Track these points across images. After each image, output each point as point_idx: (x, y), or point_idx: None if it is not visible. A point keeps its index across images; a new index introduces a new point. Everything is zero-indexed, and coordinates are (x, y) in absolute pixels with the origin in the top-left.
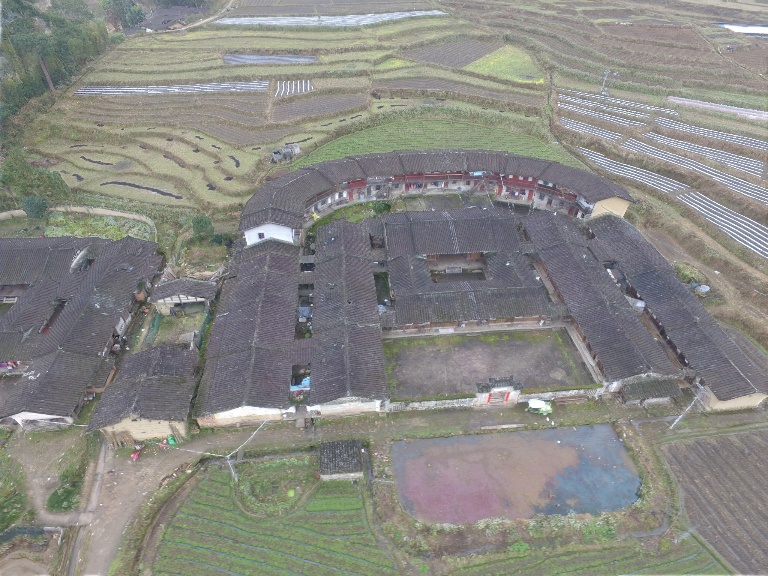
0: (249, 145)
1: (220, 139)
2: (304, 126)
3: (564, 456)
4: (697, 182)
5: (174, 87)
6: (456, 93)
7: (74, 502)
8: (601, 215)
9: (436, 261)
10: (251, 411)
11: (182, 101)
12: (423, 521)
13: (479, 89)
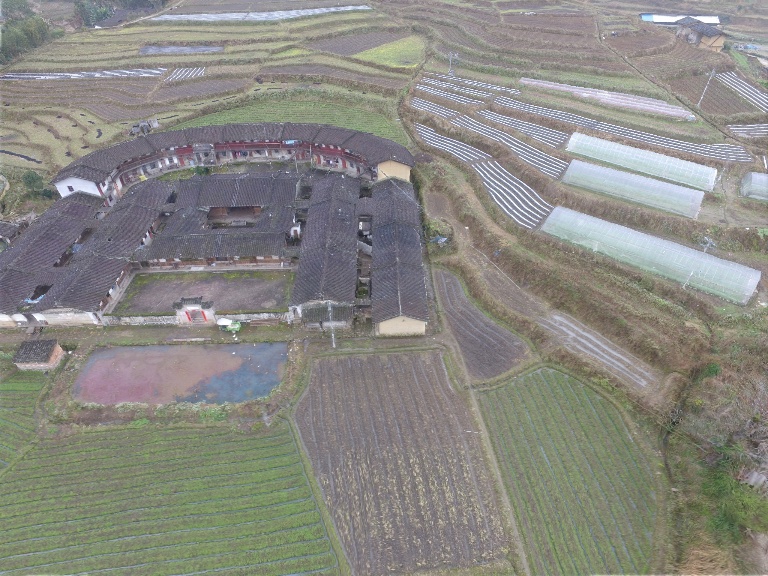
0: (119, 121)
1: (97, 116)
2: (177, 105)
3: (230, 363)
4: (497, 152)
5: (82, 73)
6: (330, 77)
7: None
8: (386, 178)
9: (227, 215)
10: None
11: (82, 85)
12: (80, 401)
13: (354, 74)
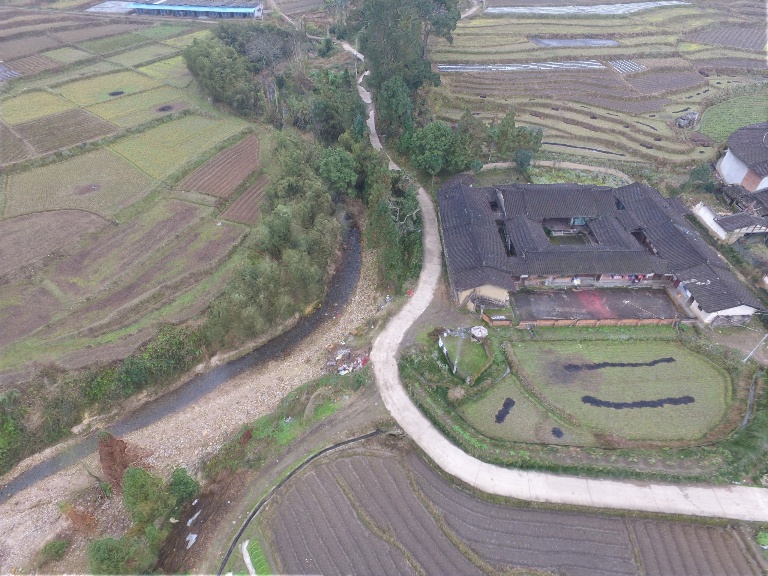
0: (642, 113)
1: (610, 108)
2: (671, 98)
3: None
4: None
5: (520, 65)
6: None
7: None
8: None
9: None
10: None
11: (541, 77)
12: None
13: None
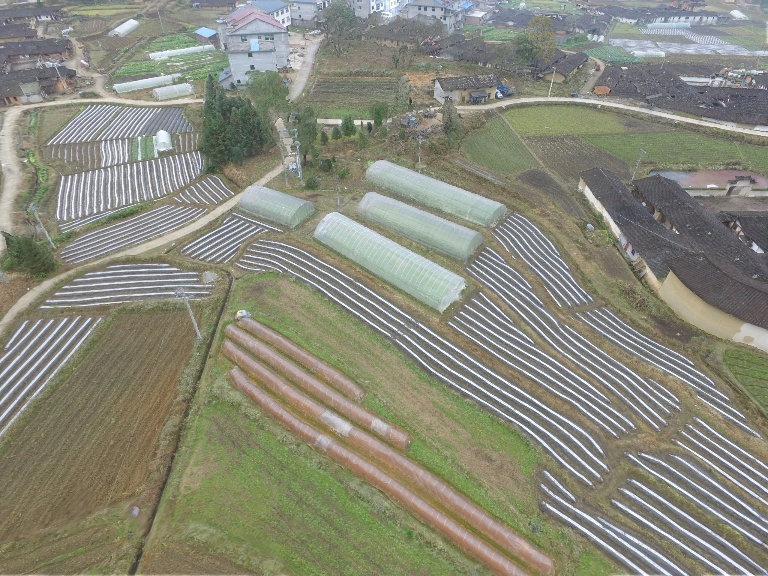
0: None
1: None
2: None
3: (687, 182)
4: None
5: None
6: None
7: None
8: None
9: None
10: None
11: None
12: (748, 171)
13: None
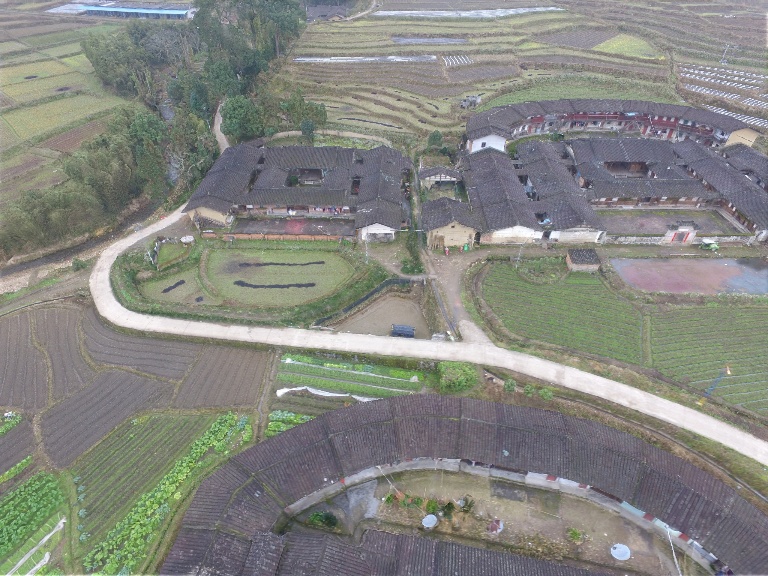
0: (439, 97)
1: (415, 92)
2: (475, 86)
3: (731, 271)
4: None
5: (365, 58)
6: (591, 66)
7: (423, 268)
8: (734, 144)
9: None
10: (516, 233)
11: (375, 67)
12: None
13: (609, 63)
